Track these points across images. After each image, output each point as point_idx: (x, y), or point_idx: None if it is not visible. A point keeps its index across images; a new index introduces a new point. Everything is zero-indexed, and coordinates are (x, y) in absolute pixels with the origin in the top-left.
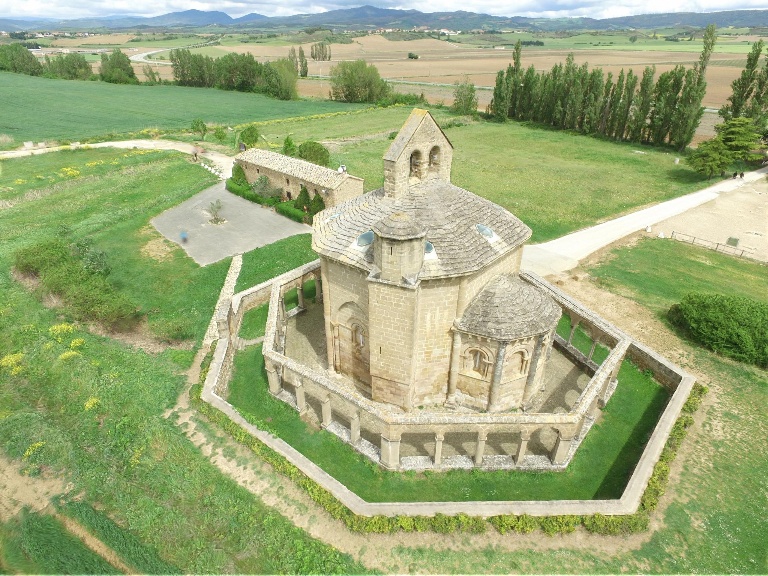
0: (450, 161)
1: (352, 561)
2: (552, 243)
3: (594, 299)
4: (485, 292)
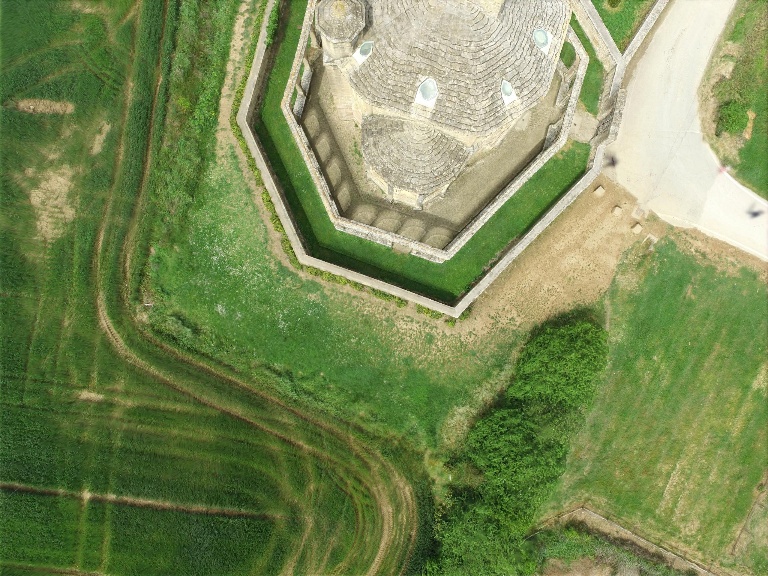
0: (502, 1)
1: (215, 127)
2: (741, 192)
3: (592, 247)
4: (402, 123)
